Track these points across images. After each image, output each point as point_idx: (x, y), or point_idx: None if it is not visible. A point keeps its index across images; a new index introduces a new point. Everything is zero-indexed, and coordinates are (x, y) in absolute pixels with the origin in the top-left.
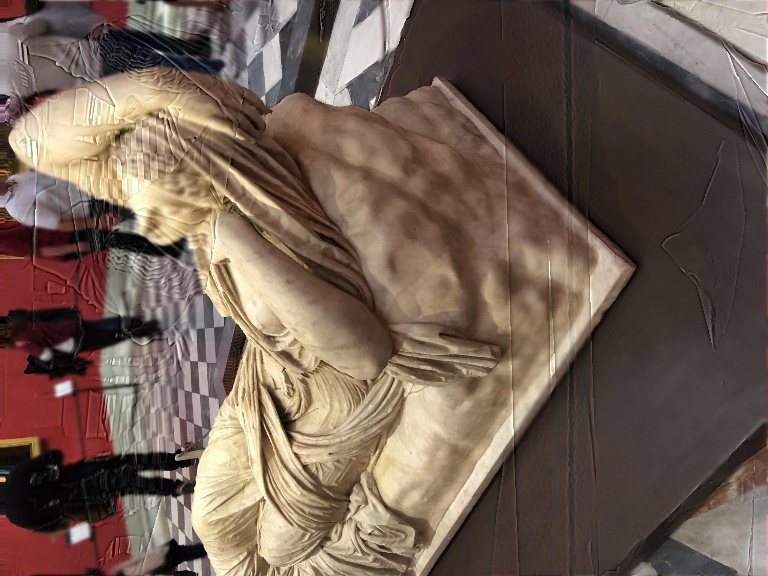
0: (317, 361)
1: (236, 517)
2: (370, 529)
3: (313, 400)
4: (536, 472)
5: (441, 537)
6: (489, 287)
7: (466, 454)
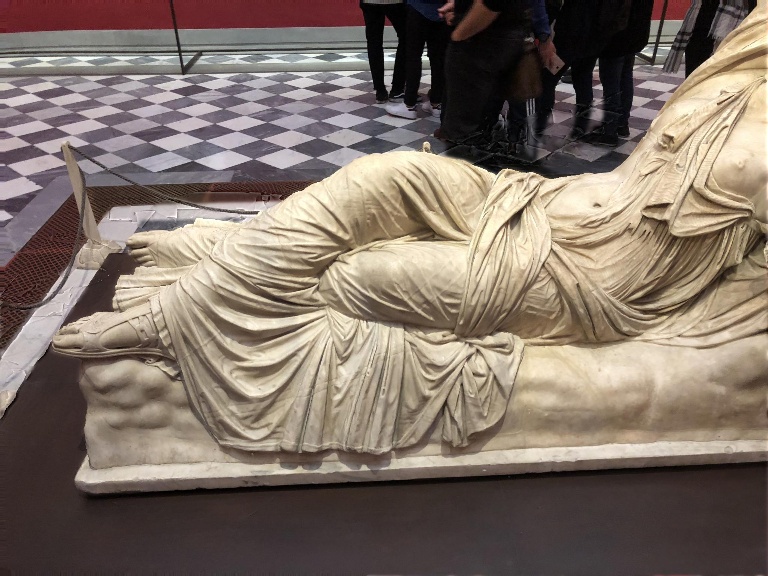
0: (687, 233)
1: (399, 210)
2: (484, 371)
3: (595, 249)
4: None
5: (484, 461)
6: None
7: (631, 425)
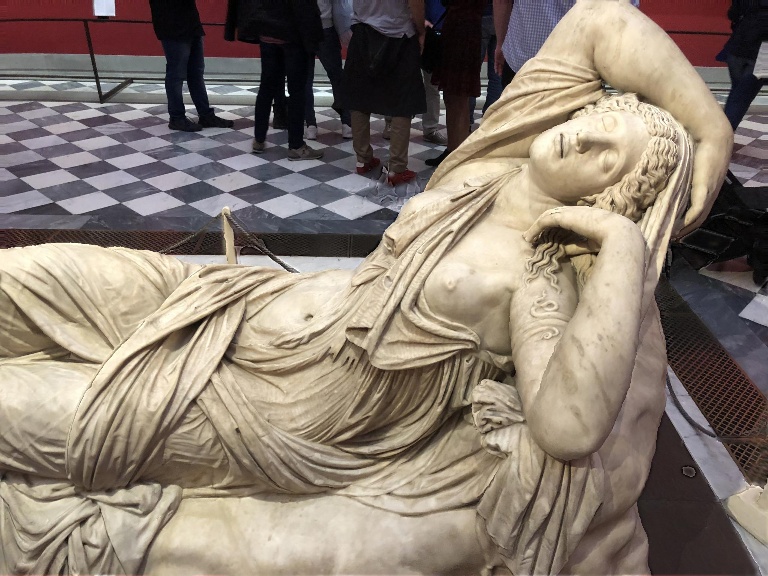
0: (392, 366)
1: (14, 323)
2: (99, 540)
3: (288, 377)
4: None
5: None
6: (625, 529)
7: None
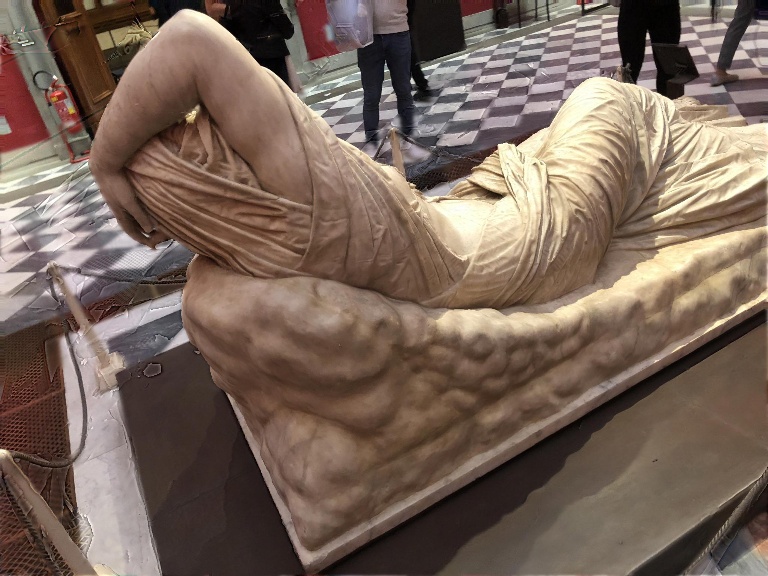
0: None
1: None
2: None
3: None
4: (29, 137)
5: None
6: None
7: None
